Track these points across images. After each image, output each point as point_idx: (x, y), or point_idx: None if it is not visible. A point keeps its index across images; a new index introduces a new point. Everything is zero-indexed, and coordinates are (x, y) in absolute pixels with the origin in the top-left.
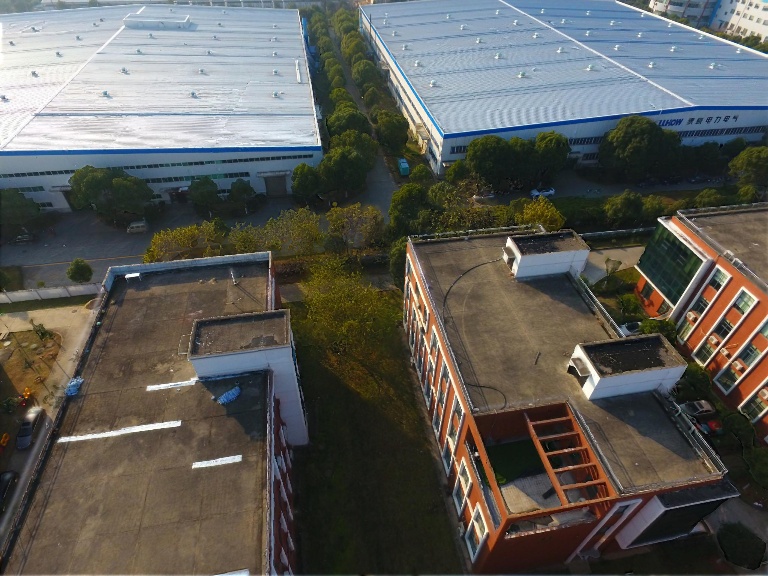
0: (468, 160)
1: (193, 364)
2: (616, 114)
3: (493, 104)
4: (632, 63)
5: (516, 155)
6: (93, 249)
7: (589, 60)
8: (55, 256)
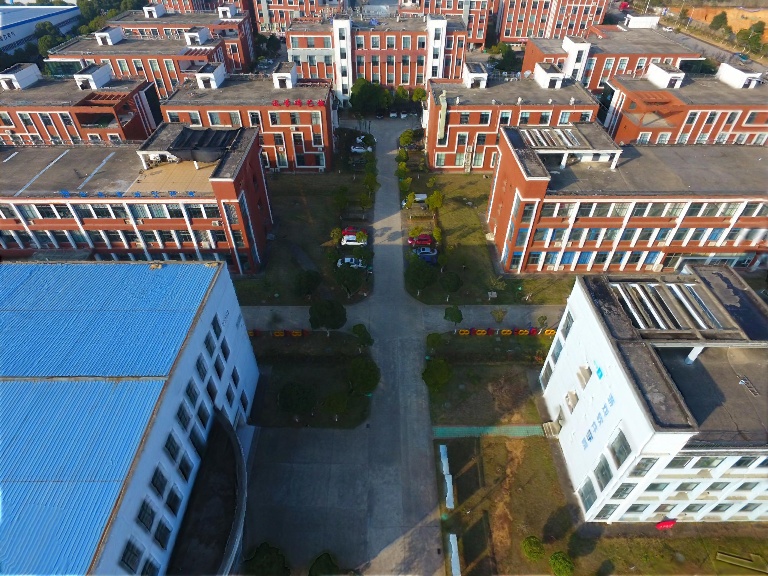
0: None
1: None
2: None
3: None
4: None
5: None
6: None
7: None
8: None
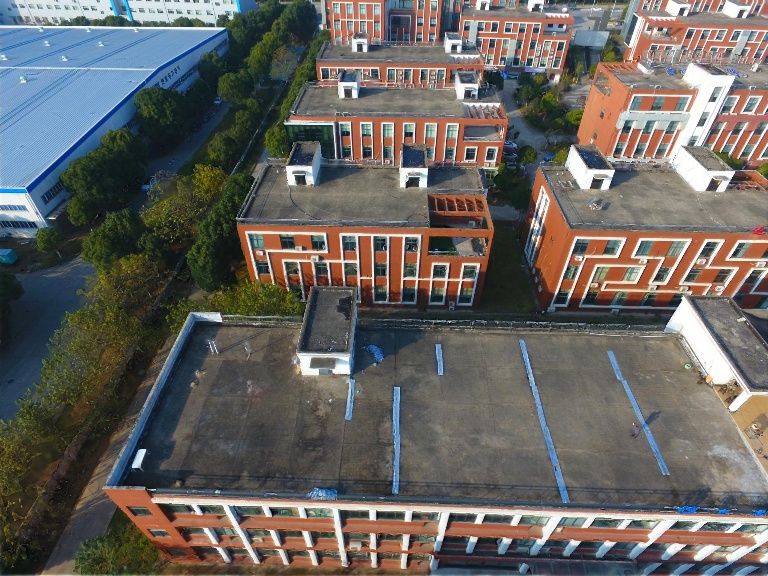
0: (83, 192)
1: None
2: (124, 97)
3: (5, 145)
4: (47, 63)
5: (115, 162)
6: None
7: (6, 75)
8: None
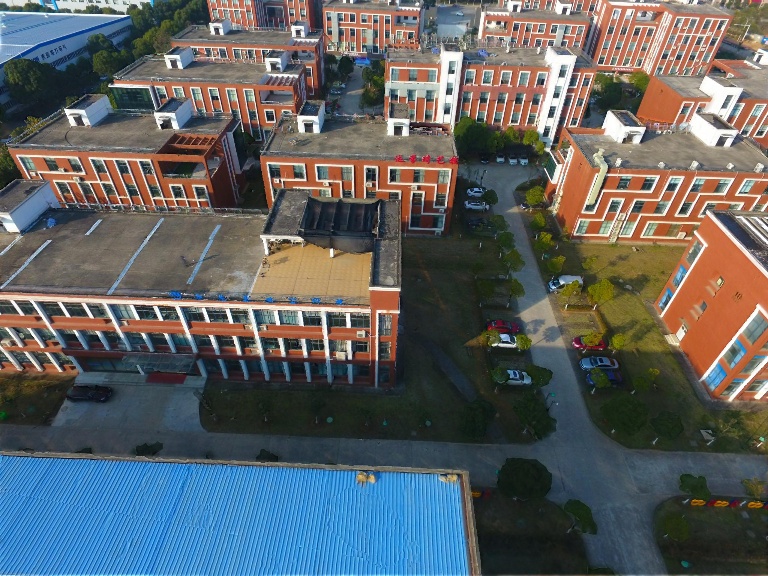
0: None
1: (13, 219)
2: None
3: None
4: None
5: None
6: None
7: None
8: None
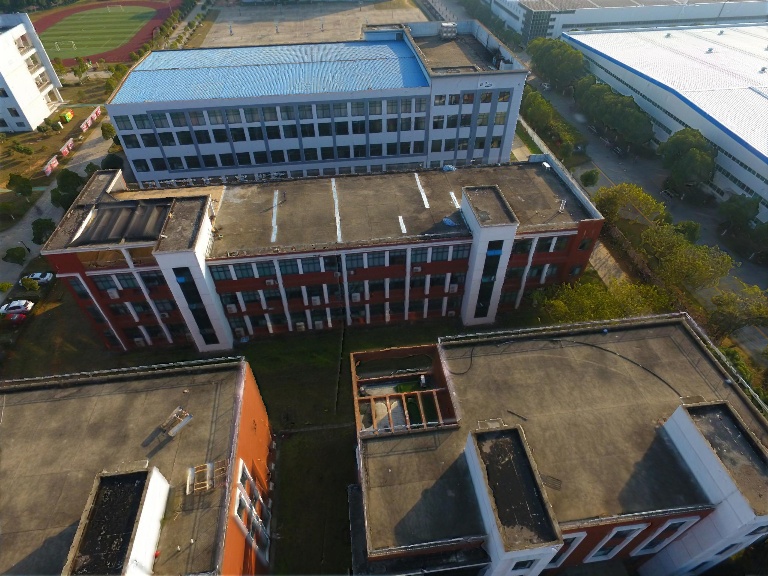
0: None
1: None
2: None
3: None
4: None
5: None
6: (629, 183)
7: None
8: (610, 170)
